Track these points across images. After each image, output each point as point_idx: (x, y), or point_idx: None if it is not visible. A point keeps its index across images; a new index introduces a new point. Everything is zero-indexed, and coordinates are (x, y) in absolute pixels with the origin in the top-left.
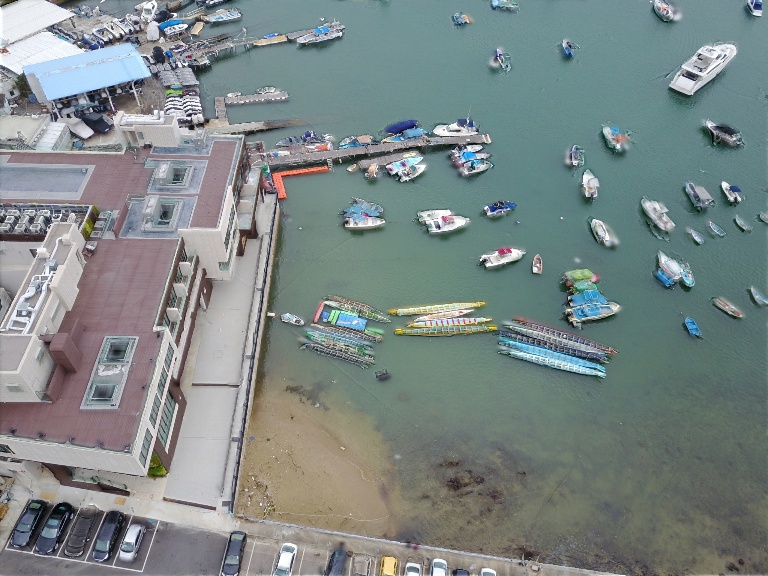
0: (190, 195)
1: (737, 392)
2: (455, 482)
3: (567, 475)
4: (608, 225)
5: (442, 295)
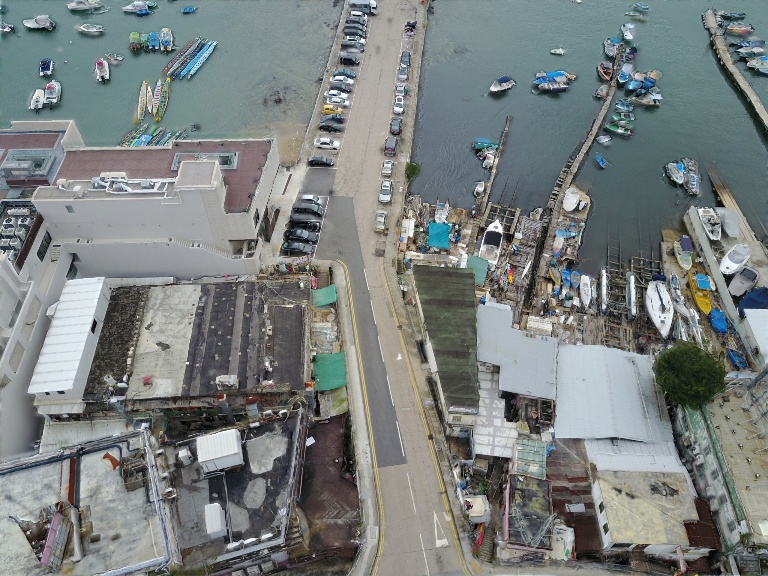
0: (5, 154)
1: (235, 7)
2: (277, 100)
3: (277, 65)
4: (89, 22)
5: (128, 101)
